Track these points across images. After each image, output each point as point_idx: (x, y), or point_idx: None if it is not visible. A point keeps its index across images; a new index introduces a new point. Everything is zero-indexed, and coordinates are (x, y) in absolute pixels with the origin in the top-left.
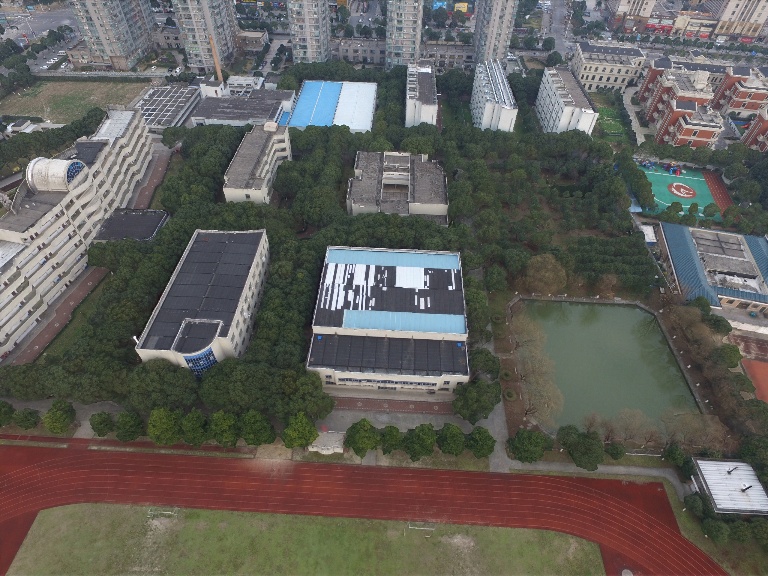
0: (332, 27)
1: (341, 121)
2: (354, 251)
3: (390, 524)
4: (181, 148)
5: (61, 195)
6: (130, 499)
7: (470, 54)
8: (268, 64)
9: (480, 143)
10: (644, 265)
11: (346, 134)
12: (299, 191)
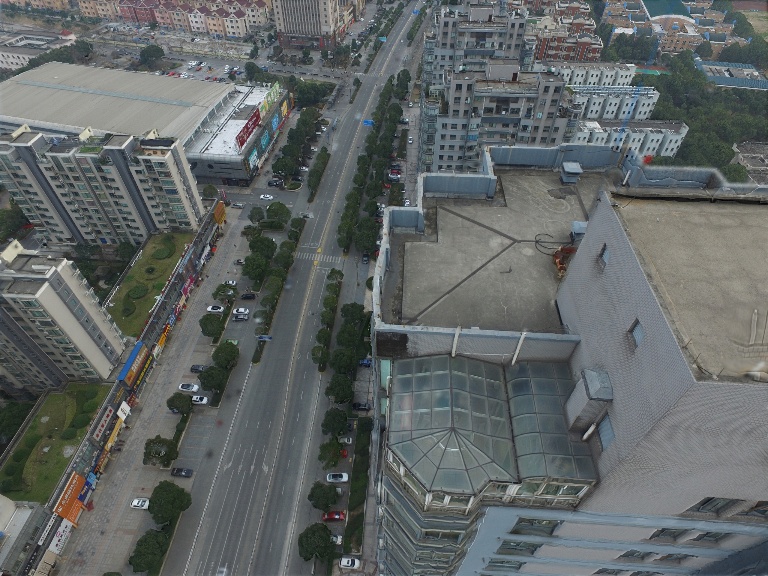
0: (371, 218)
1: None
2: None
3: None
4: None
5: None
6: None
7: None
8: None
9: None
10: None
11: None
12: None
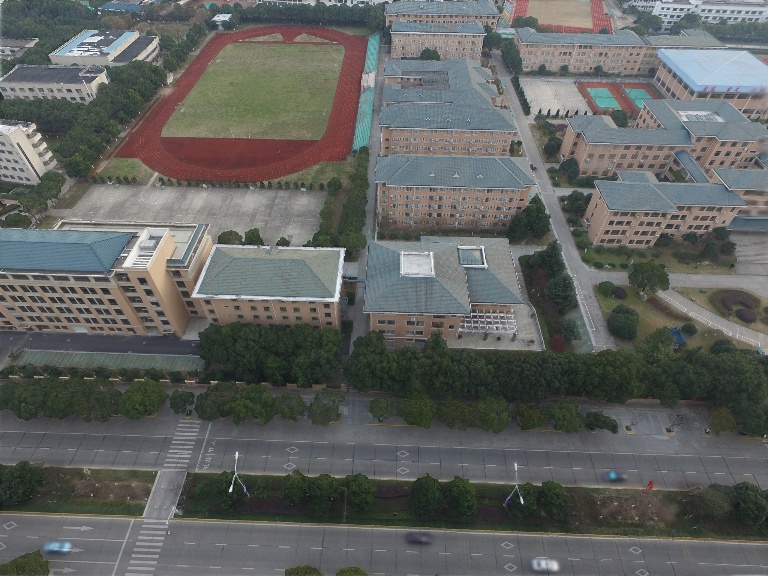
0: None
1: None
2: (59, 51)
3: (207, 70)
4: None
5: None
6: None
7: None
8: None
9: None
10: (124, 12)
11: None
12: None
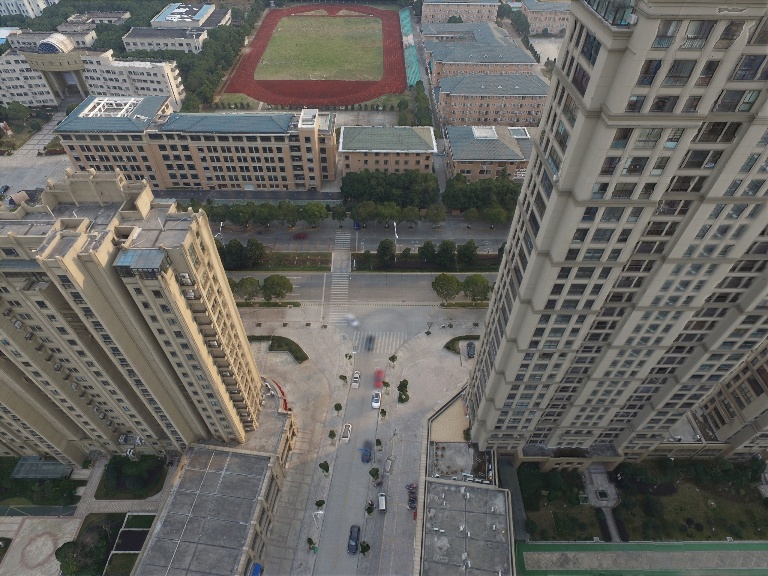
0: None
1: (4, 36)
2: None
3: None
4: None
5: None
6: (255, 67)
7: None
8: None
9: None
10: None
11: None
12: None
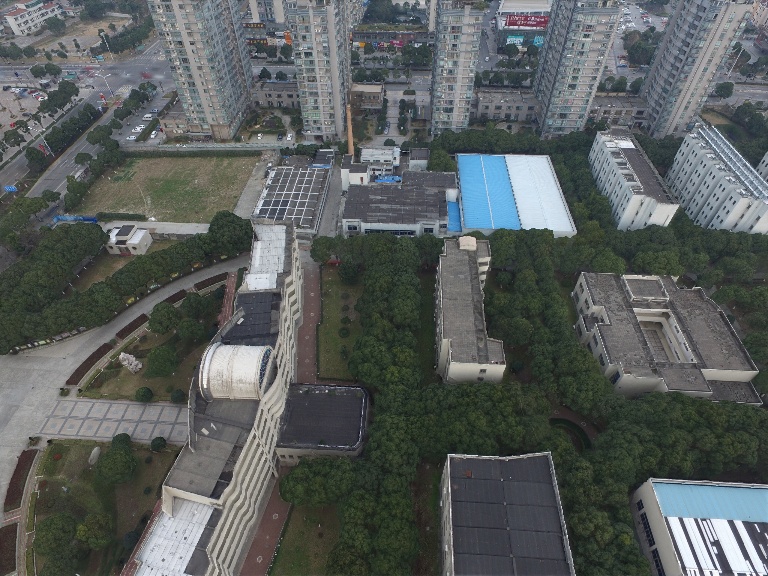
0: None
1: (530, 217)
2: (691, 487)
3: None
4: (341, 268)
5: (247, 405)
6: None
7: (642, 109)
8: (392, 126)
9: (741, 255)
10: None
11: (552, 242)
12: (535, 348)
